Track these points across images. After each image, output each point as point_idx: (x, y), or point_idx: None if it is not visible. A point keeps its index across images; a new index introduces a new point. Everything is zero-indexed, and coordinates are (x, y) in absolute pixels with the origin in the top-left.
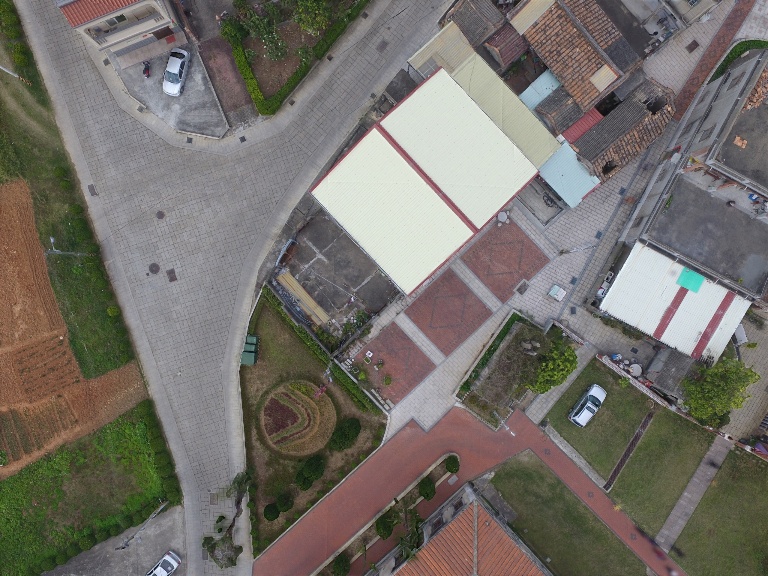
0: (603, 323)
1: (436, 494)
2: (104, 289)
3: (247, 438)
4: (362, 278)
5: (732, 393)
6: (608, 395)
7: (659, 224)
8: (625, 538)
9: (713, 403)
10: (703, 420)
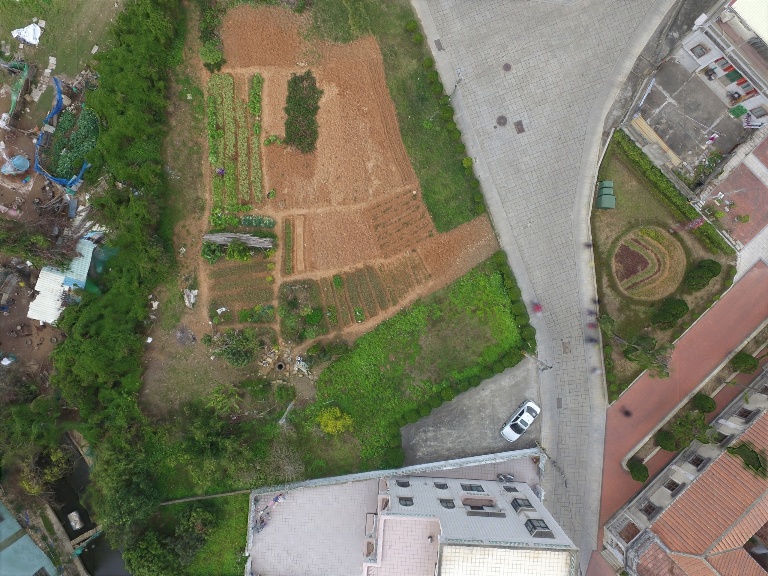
0: None
1: None
2: (454, 143)
3: (599, 285)
4: (712, 120)
5: None
6: None
7: None
8: None
9: None
10: None
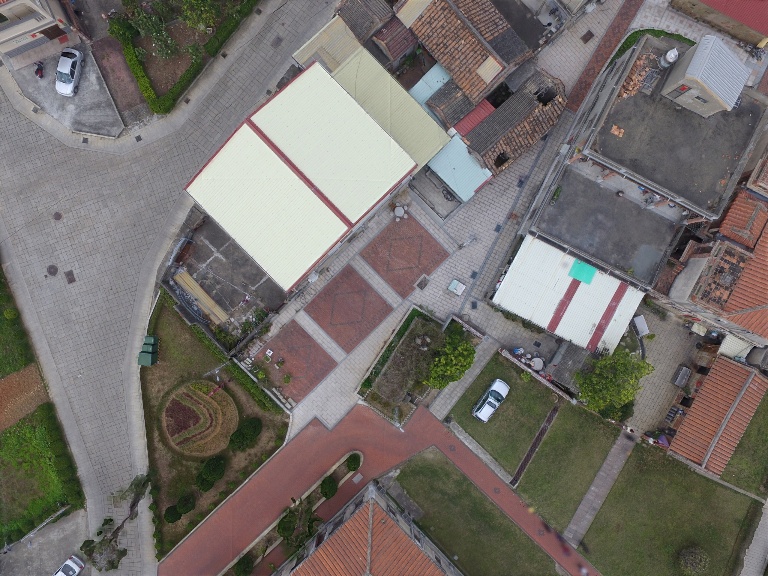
0: (504, 317)
1: (341, 493)
2: (2, 292)
3: (149, 440)
4: (260, 276)
5: (623, 385)
6: (512, 390)
7: (548, 216)
8: (533, 534)
9: (603, 395)
10: (604, 413)
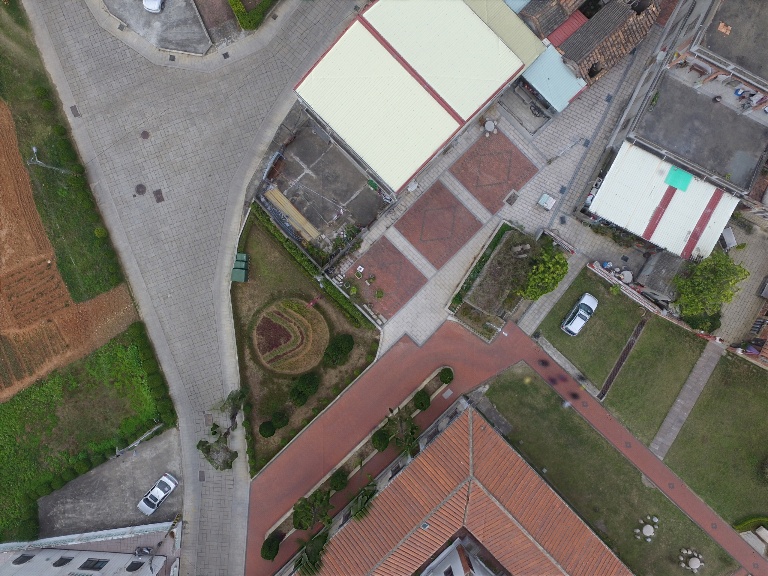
0: (593, 231)
1: (431, 408)
2: (91, 211)
3: (240, 358)
4: (351, 192)
5: (722, 287)
6: (600, 304)
7: (646, 122)
8: (620, 446)
9: (703, 297)
10: (694, 323)
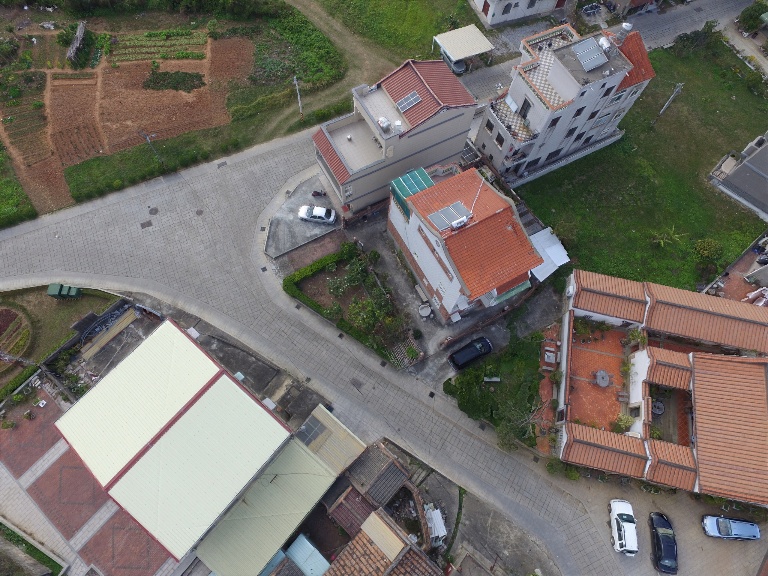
0: None
1: None
2: None
3: None
4: None
5: None
6: None
7: None
8: None
9: None
10: None
